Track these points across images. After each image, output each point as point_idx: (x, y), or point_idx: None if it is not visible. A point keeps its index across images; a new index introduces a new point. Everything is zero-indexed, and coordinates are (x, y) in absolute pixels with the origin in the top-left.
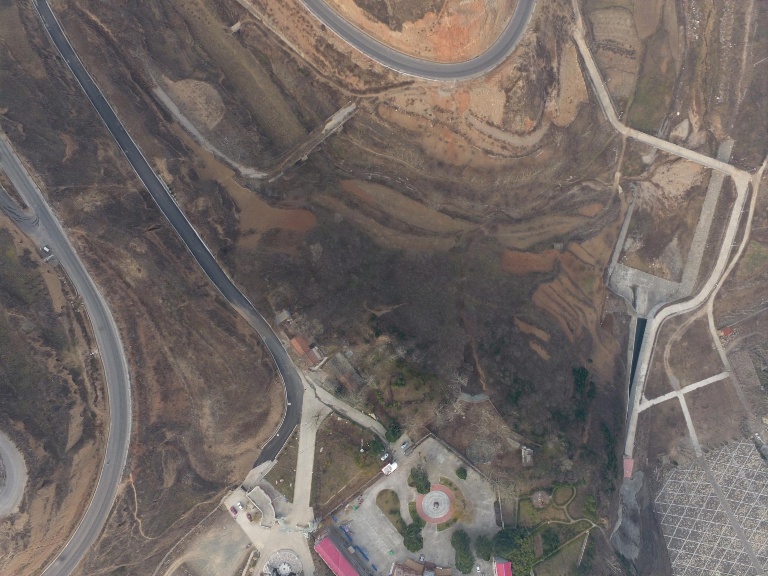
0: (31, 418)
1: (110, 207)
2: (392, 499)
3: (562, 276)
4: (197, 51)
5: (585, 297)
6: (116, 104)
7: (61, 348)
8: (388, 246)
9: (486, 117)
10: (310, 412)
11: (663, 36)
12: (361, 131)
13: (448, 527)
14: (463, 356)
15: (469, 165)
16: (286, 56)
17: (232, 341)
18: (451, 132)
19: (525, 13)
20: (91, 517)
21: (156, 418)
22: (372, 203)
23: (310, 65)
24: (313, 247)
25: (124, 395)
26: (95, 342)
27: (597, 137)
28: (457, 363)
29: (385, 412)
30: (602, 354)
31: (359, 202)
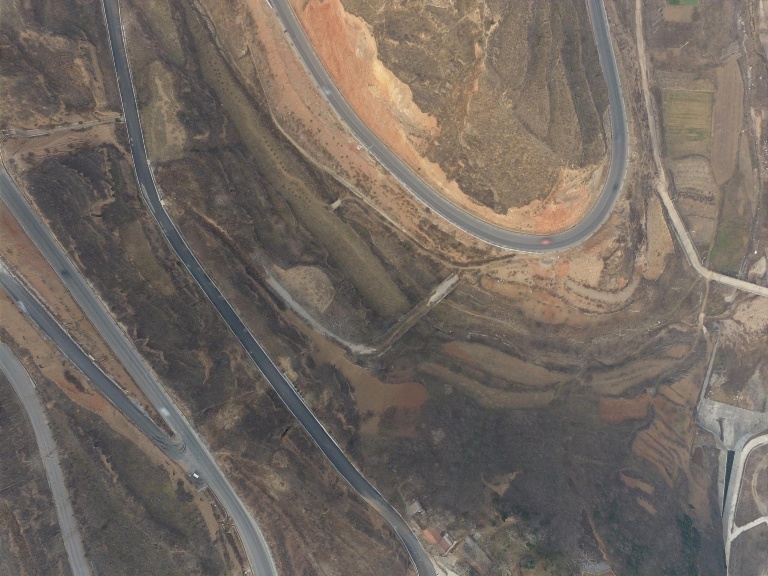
0: None
1: (246, 419)
2: None
3: (656, 421)
4: (300, 231)
5: (678, 437)
6: (239, 307)
7: (218, 574)
8: (492, 406)
9: (583, 281)
10: None
11: (739, 180)
12: (461, 297)
13: None
14: (583, 528)
15: (566, 323)
16: (387, 231)
17: (372, 542)
18: (549, 296)
19: (617, 180)
20: None
21: None
22: (473, 363)
23: (411, 239)
24: (435, 433)
25: None
26: (247, 561)
27: (682, 282)
28: None
29: None
30: (697, 493)
31: (462, 364)
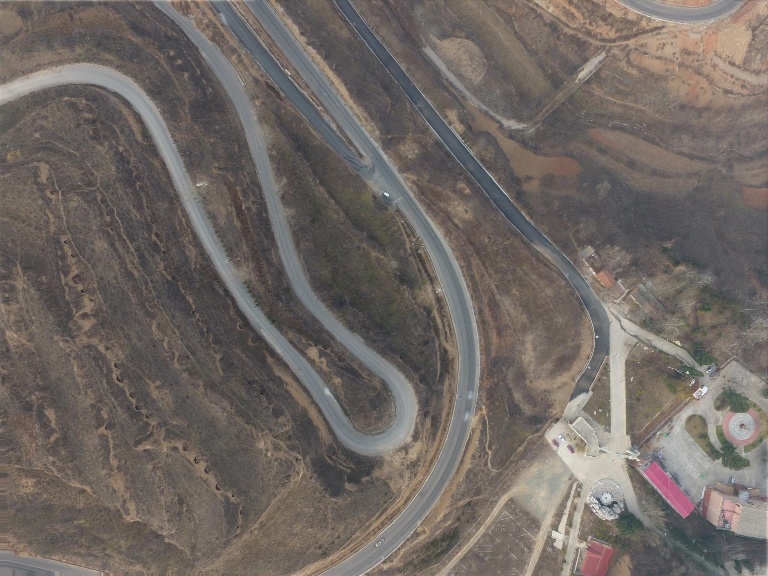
0: (405, 352)
1: (425, 155)
2: (701, 424)
3: None
4: (448, 13)
5: None
6: (406, 61)
7: (413, 287)
8: (638, 189)
9: (729, 57)
10: (618, 343)
11: None
12: (605, 80)
13: (754, 448)
14: None
15: (709, 106)
16: (533, 12)
17: (553, 275)
18: (695, 74)
19: None
20: (448, 451)
21: (495, 352)
22: (617, 149)
23: (557, 19)
24: (601, 186)
25: (470, 330)
26: (438, 281)
27: None
28: (745, 289)
29: (690, 338)
30: None
31: (607, 148)
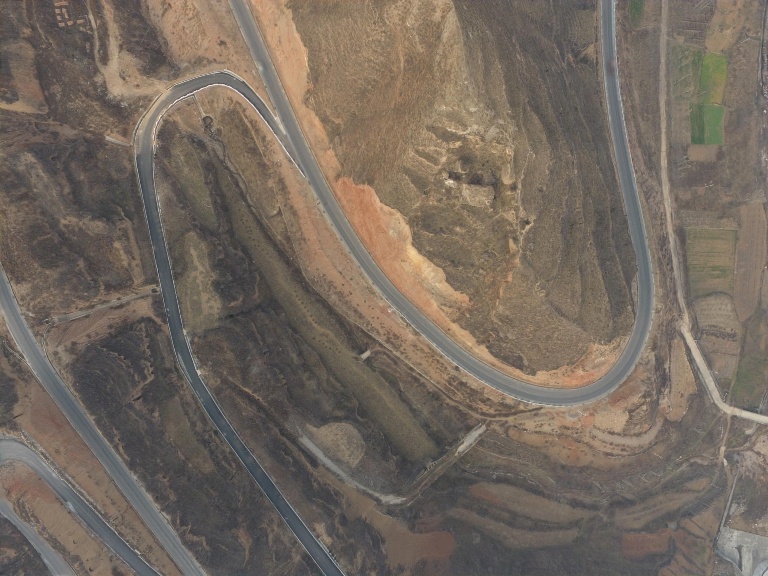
0: None
1: None
2: None
3: (678, 555)
4: (331, 382)
5: (698, 569)
6: (274, 475)
7: None
8: (517, 546)
9: (608, 429)
10: None
11: (761, 316)
12: (488, 442)
13: None
14: None
15: (590, 465)
16: (416, 382)
17: None
18: (575, 442)
19: (642, 331)
20: None
21: None
22: (499, 504)
23: (440, 390)
24: None
25: None
26: None
27: (703, 418)
28: None
29: None
30: None
31: (488, 506)
